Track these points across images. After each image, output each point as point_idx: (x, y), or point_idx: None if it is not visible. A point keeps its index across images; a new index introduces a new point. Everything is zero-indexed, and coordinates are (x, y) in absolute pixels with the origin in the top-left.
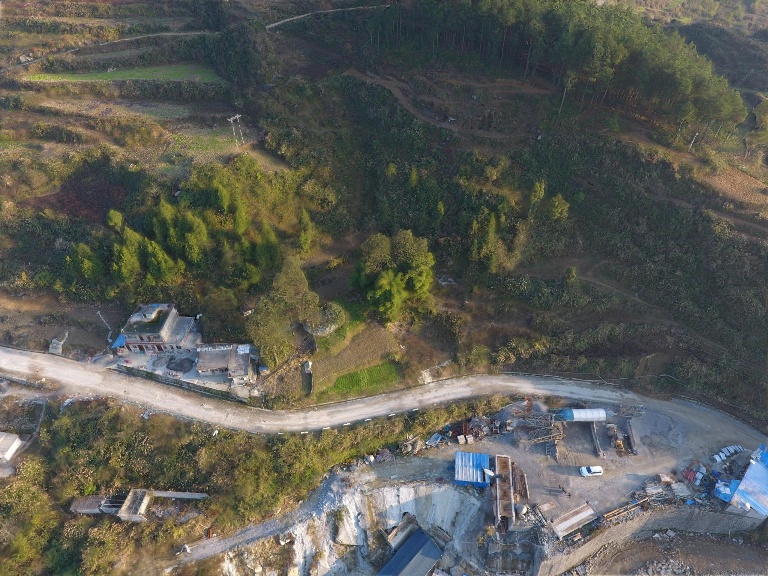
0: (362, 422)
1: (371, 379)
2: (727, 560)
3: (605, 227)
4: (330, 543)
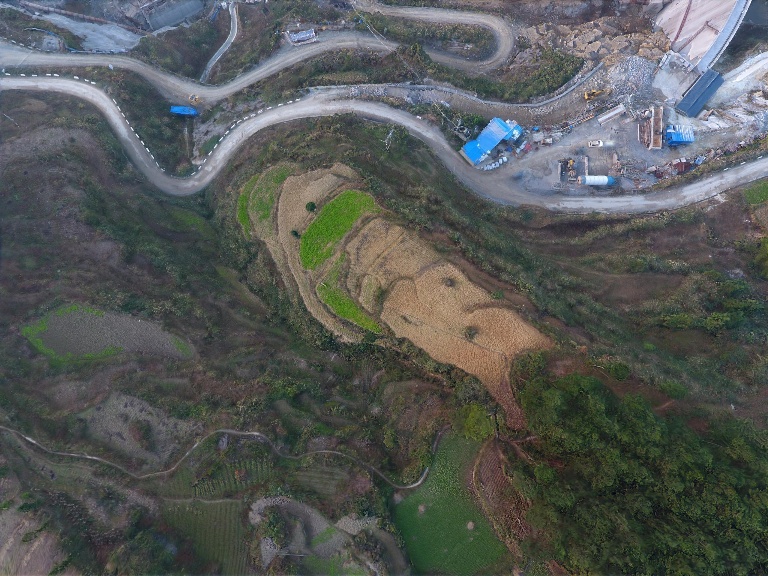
0: (764, 155)
1: (766, 188)
2: (506, 114)
3: (611, 320)
4: (745, 107)
